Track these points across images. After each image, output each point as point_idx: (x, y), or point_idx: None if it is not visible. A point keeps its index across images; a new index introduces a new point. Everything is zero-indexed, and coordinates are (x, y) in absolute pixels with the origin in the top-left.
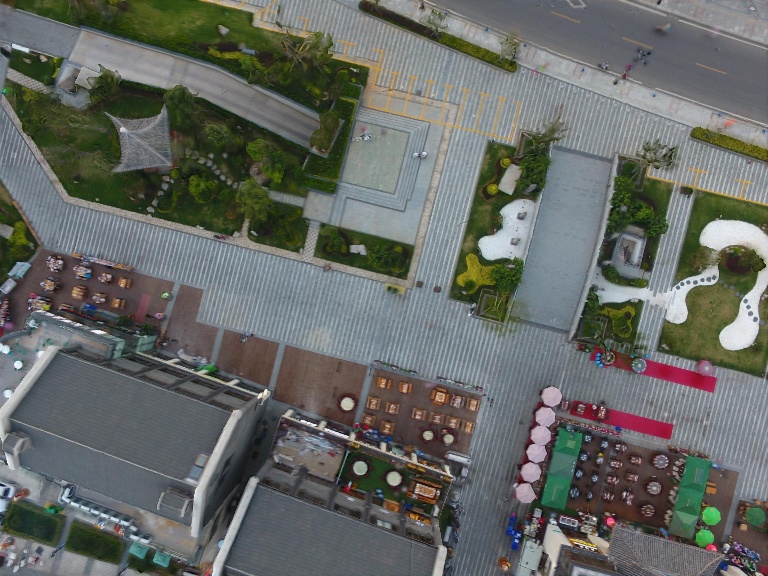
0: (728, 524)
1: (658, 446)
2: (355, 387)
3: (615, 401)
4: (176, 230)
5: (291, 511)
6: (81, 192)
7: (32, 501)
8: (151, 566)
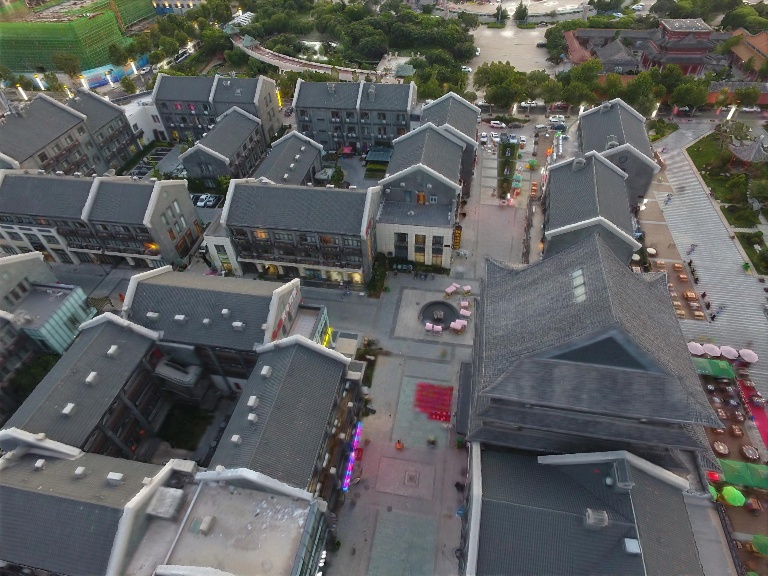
0: None
1: (761, 454)
2: (663, 256)
3: None
4: (700, 181)
5: (621, 187)
6: (691, 152)
7: (518, 150)
8: None
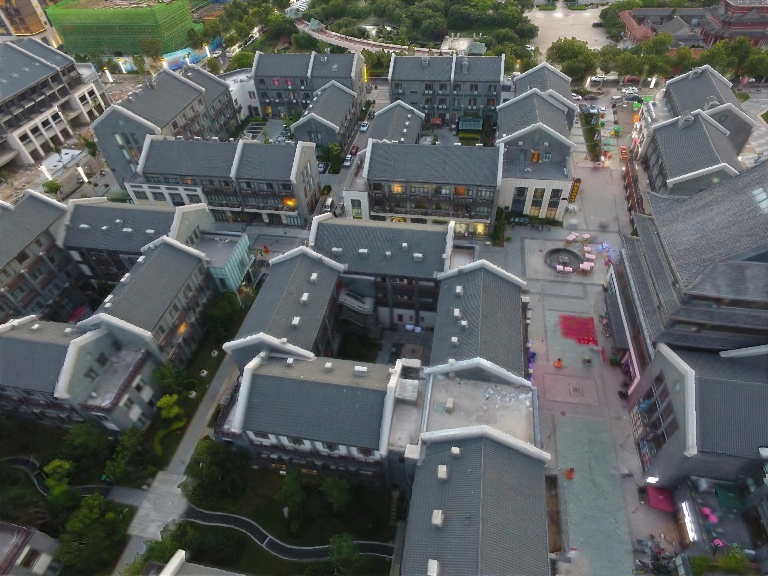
0: None
1: None
2: None
3: None
4: None
5: None
6: (766, 118)
7: (600, 119)
8: (595, 150)
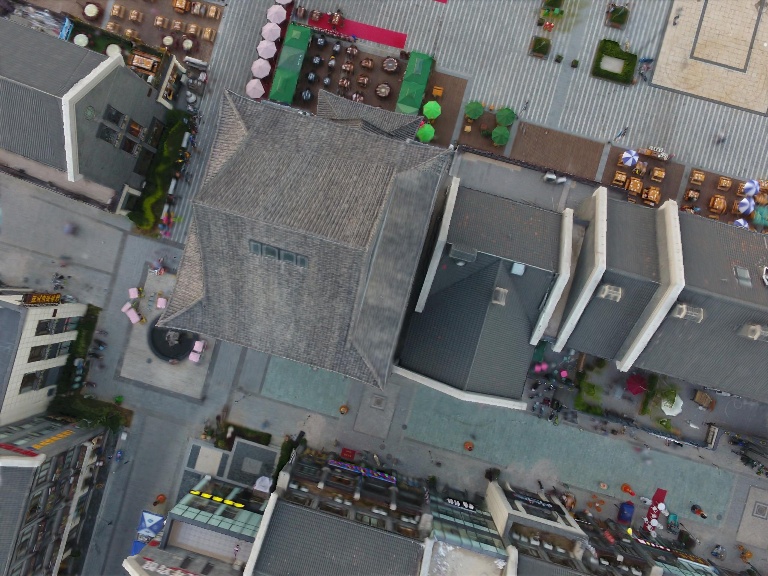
0: (456, 130)
1: (391, 54)
2: None
3: (352, 12)
4: None
5: None
6: None
7: None
8: None
